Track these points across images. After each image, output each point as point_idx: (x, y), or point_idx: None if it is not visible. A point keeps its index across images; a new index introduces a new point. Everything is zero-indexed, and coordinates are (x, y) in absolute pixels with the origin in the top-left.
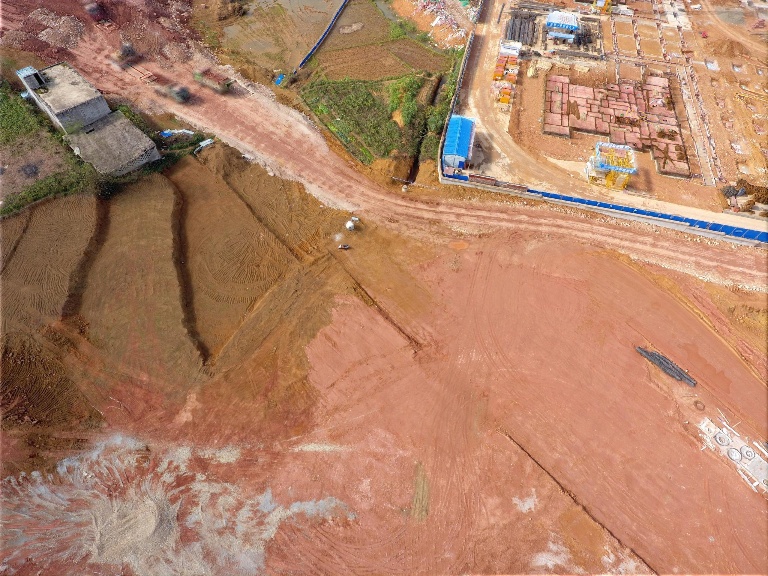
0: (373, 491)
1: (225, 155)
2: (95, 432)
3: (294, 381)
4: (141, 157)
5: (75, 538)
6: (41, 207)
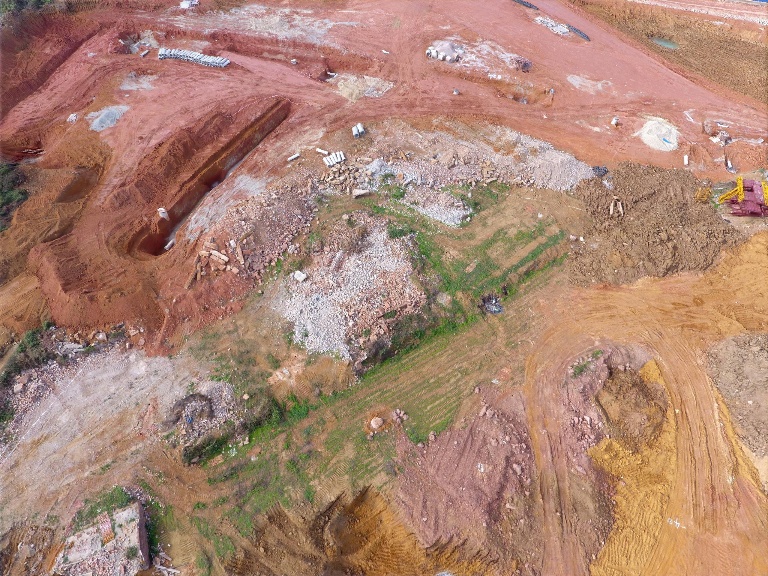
0: (375, 21)
1: None
2: (244, 4)
3: None
4: None
5: (244, 25)
6: None
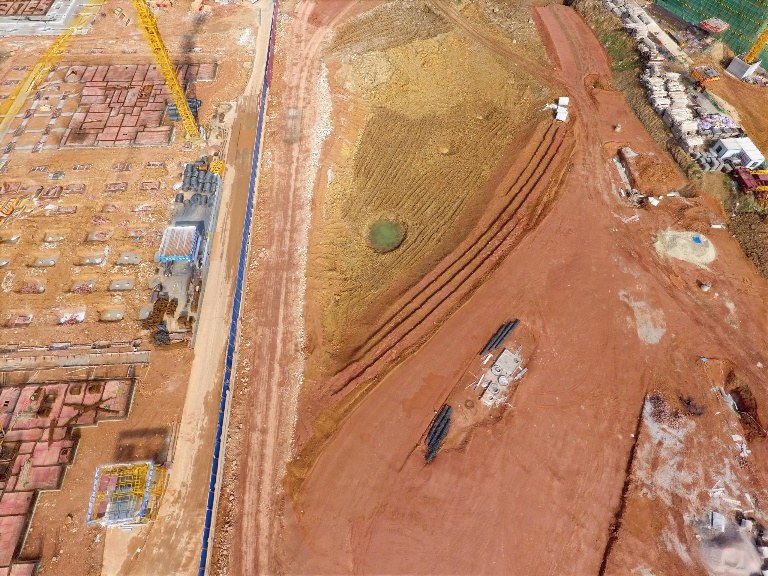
0: None
1: None
2: None
3: None
4: None
5: None
6: None
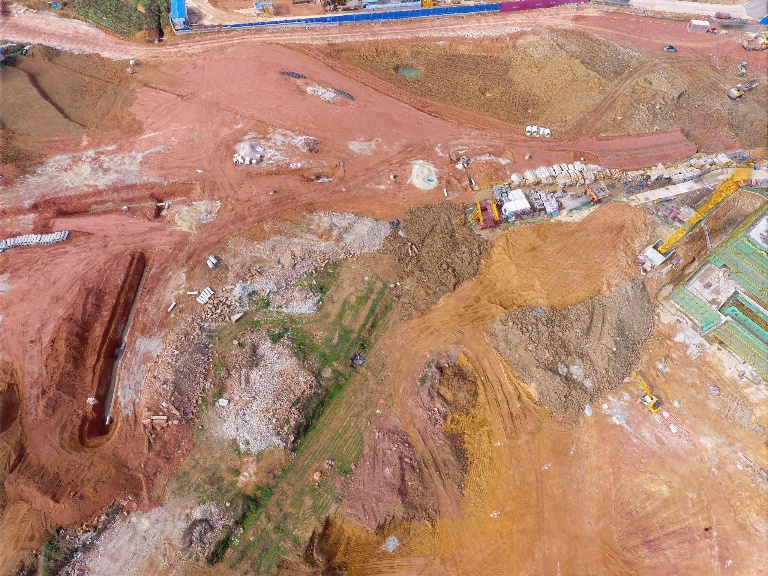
0: (177, 139)
1: (44, 49)
2: (46, 159)
3: (129, 121)
4: None
5: (59, 185)
6: None
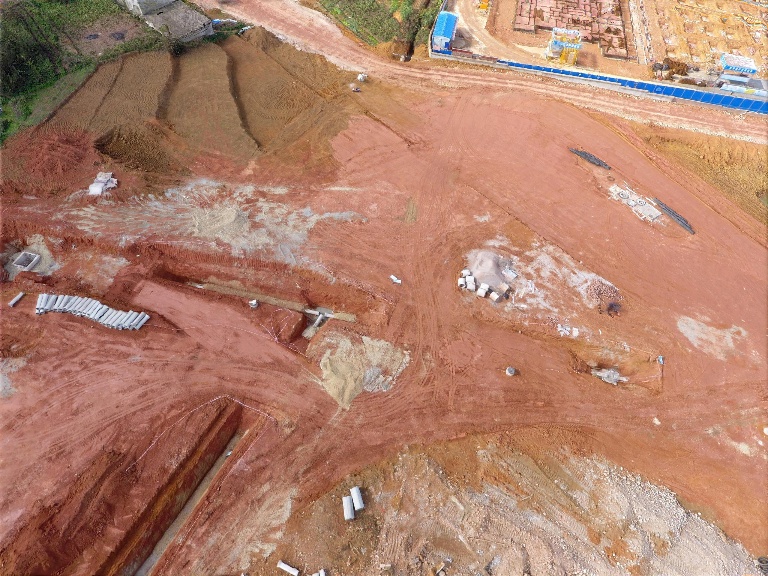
0: (379, 209)
1: (263, 34)
2: (187, 178)
3: (323, 157)
4: (201, 29)
5: (182, 225)
6: (130, 58)
